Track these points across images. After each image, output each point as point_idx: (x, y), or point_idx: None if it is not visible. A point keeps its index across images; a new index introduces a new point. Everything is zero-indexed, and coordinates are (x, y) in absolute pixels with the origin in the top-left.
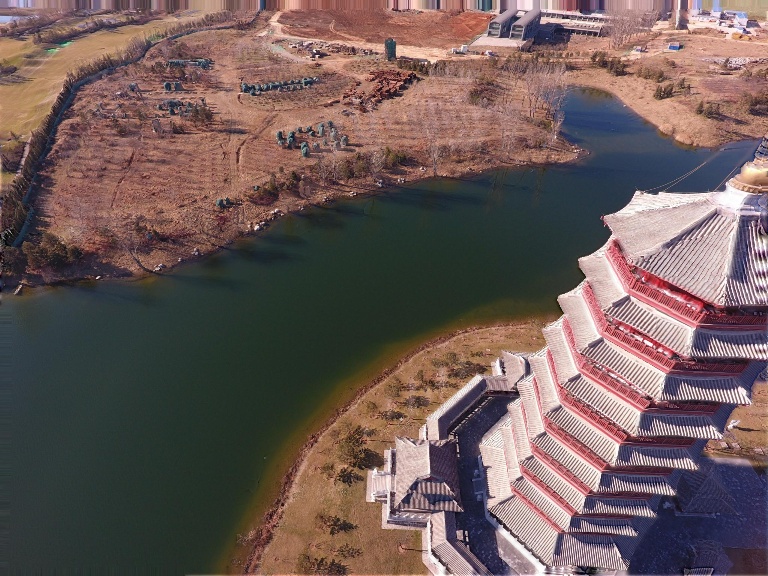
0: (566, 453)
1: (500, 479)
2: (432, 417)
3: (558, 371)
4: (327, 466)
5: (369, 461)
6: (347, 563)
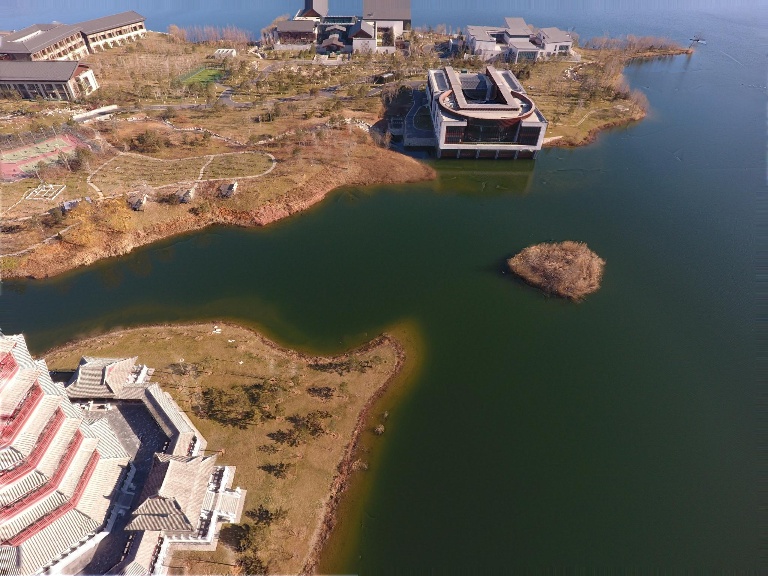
0: (41, 384)
1: (103, 480)
2: (140, 569)
3: (3, 356)
4: (281, 512)
5: (236, 535)
6: (270, 441)
